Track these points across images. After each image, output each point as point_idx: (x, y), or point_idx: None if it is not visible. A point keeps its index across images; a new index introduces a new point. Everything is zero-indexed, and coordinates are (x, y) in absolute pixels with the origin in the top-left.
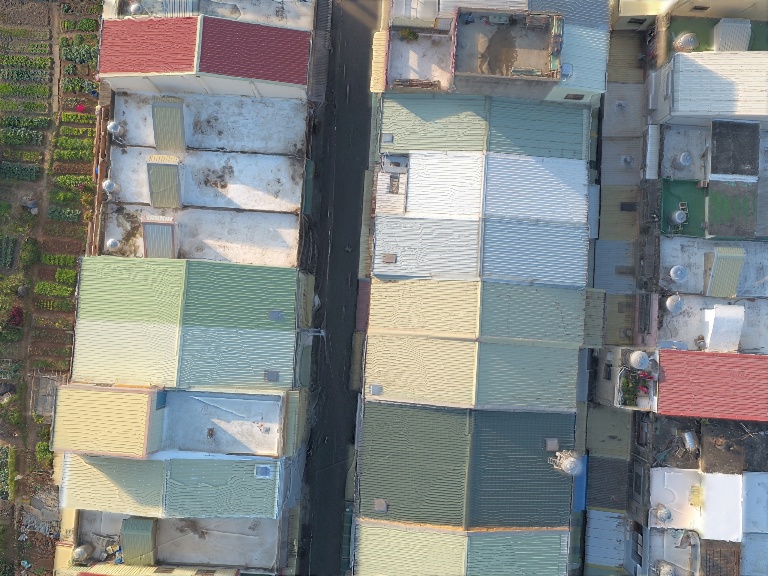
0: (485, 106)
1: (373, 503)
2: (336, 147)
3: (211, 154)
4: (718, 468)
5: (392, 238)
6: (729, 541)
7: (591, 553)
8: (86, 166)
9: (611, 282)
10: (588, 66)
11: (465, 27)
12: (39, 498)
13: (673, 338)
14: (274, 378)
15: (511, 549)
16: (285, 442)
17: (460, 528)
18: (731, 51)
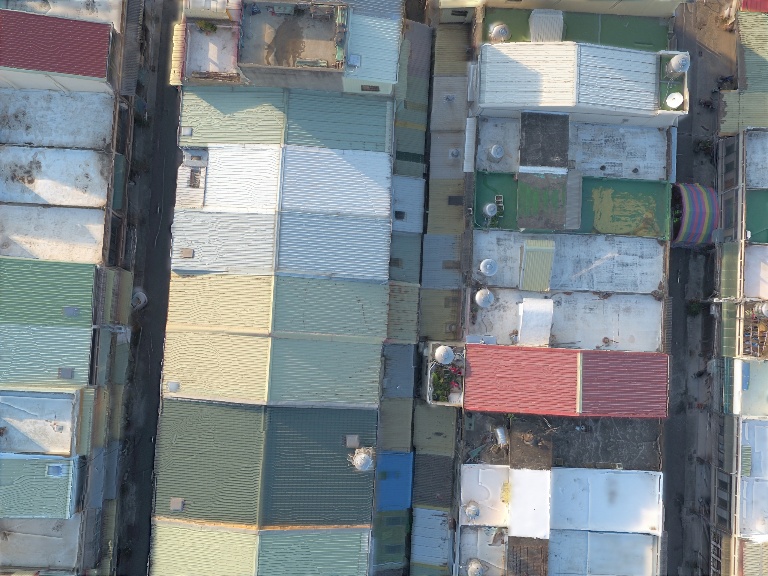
0: (283, 98)
1: (169, 502)
2: (166, 143)
3: (18, 149)
4: (526, 464)
5: (180, 232)
6: (536, 538)
7: (416, 552)
8: None
9: (438, 277)
10: (378, 57)
11: (251, 18)
12: None
13: (488, 333)
14: (68, 376)
15: (307, 548)
16: (79, 441)
17: (253, 527)
18: (536, 42)
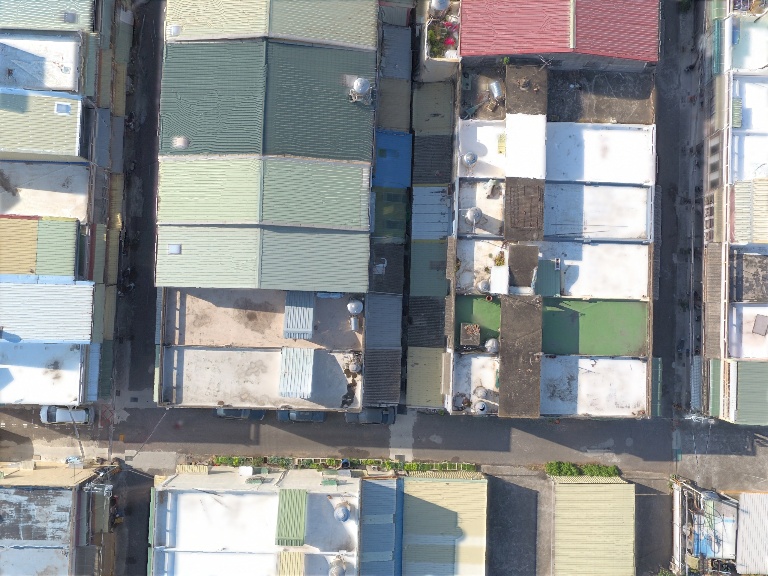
0: None
1: (175, 140)
2: None
3: None
4: (522, 109)
5: None
6: (533, 178)
7: (417, 229)
8: None
9: None
10: None
11: None
12: None
13: None
14: (74, 20)
15: (310, 177)
16: (86, 82)
17: (258, 155)
18: None
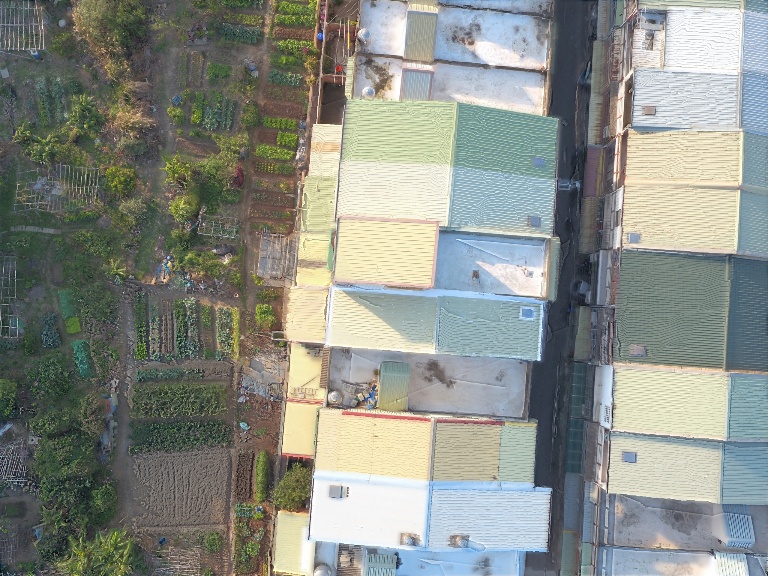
0: None
1: (632, 348)
2: None
3: (458, 11)
4: None
5: (664, 84)
6: None
7: None
8: (307, 32)
9: None
10: None
11: None
12: (259, 360)
13: None
14: (537, 223)
15: (767, 392)
16: (548, 286)
17: (721, 370)
18: None
